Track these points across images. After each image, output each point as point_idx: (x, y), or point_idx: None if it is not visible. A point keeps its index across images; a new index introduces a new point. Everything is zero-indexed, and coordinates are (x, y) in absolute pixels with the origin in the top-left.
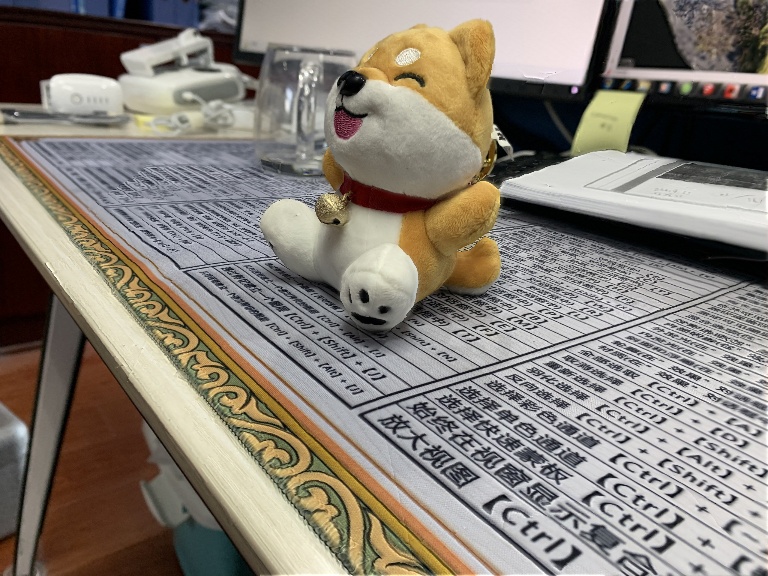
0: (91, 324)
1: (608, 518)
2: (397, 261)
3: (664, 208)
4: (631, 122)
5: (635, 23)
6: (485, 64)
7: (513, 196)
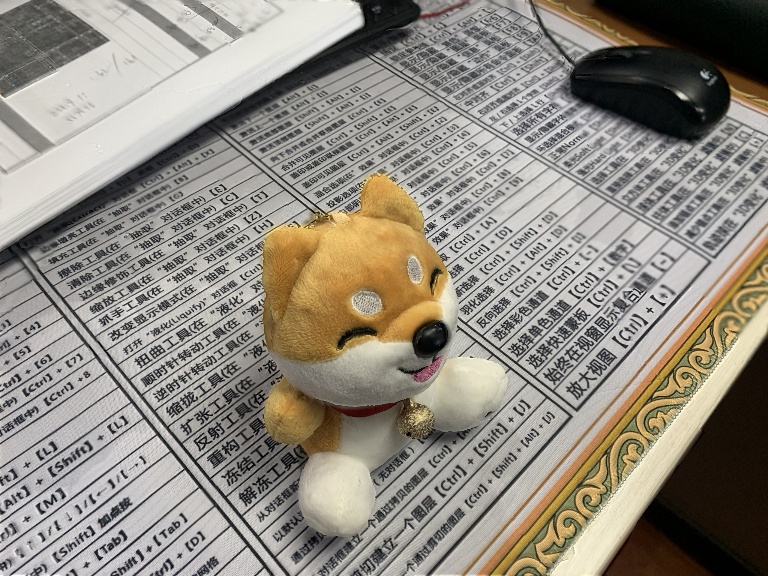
0: None
1: (606, 300)
2: (488, 365)
3: (142, 133)
4: None
5: None
6: None
7: None
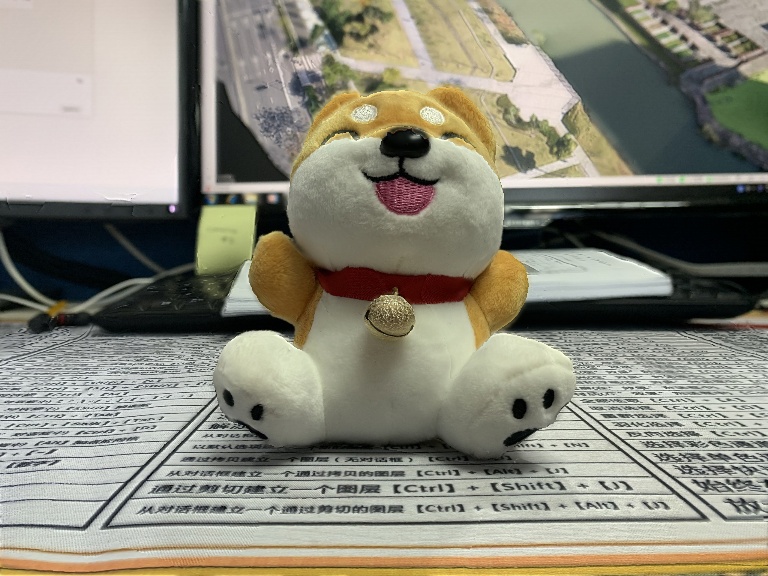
0: None
1: None
2: None
3: None
4: (251, 233)
5: (223, 143)
6: None
7: (248, 312)
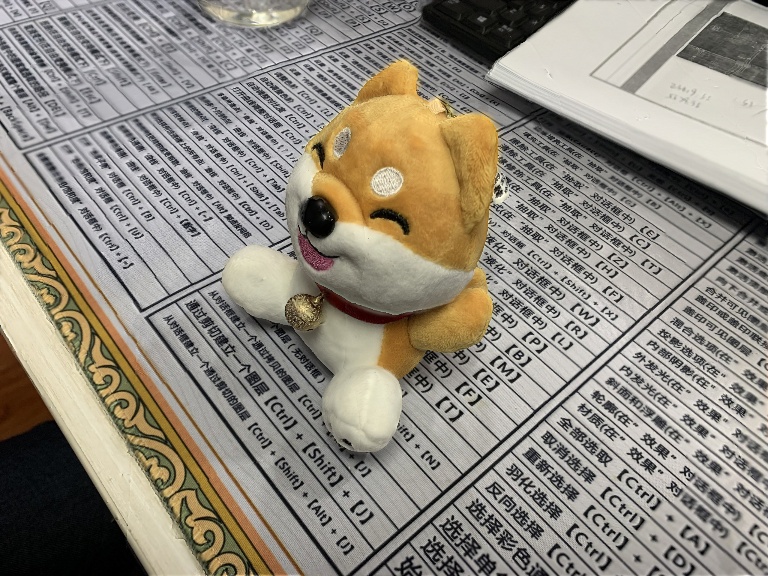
0: (68, 439)
1: None
2: (380, 412)
3: (676, 140)
4: None
5: None
6: (485, 197)
7: (506, 86)
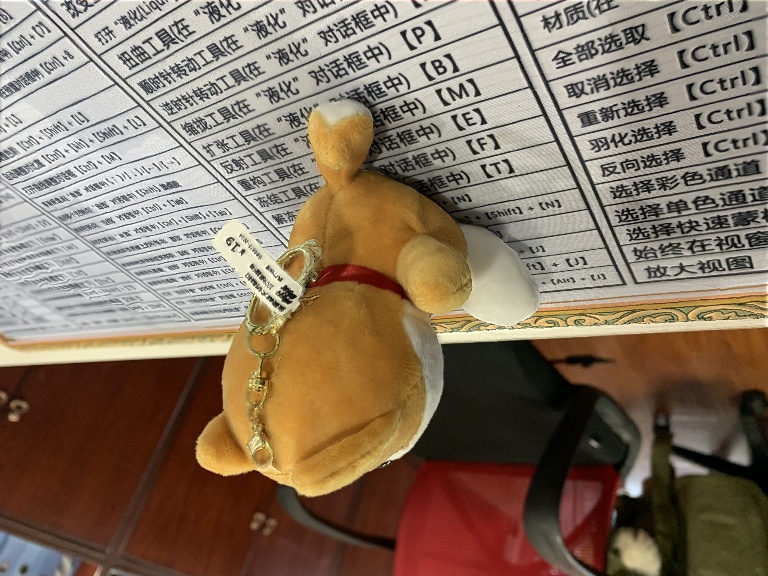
0: None
1: None
2: (513, 314)
3: None
4: None
5: None
6: None
7: None
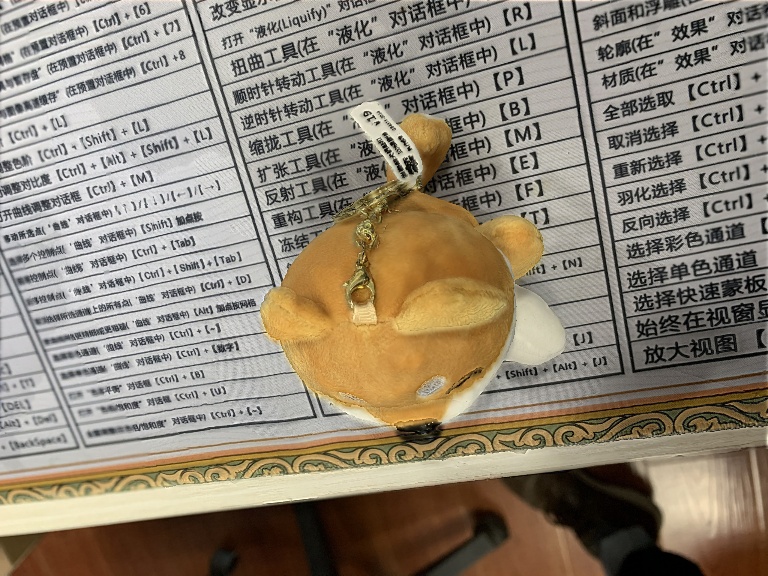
0: (411, 487)
1: None
2: (547, 339)
3: None
4: None
5: None
6: None
7: None
